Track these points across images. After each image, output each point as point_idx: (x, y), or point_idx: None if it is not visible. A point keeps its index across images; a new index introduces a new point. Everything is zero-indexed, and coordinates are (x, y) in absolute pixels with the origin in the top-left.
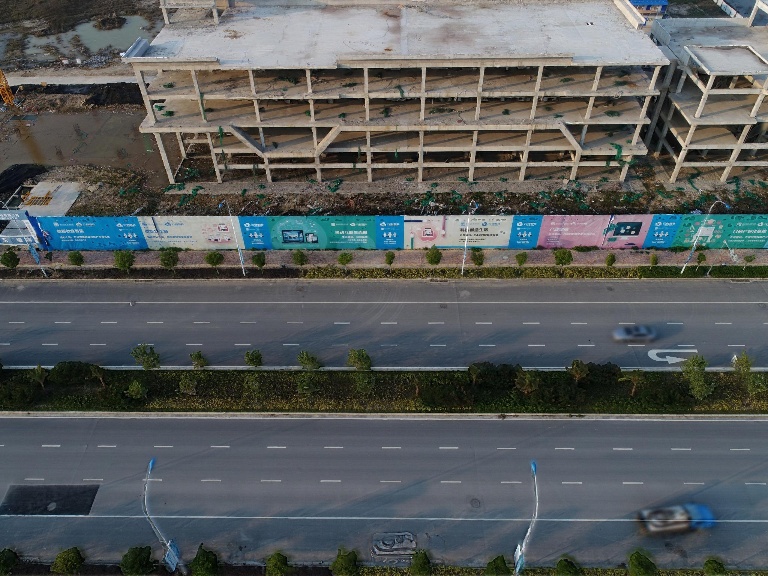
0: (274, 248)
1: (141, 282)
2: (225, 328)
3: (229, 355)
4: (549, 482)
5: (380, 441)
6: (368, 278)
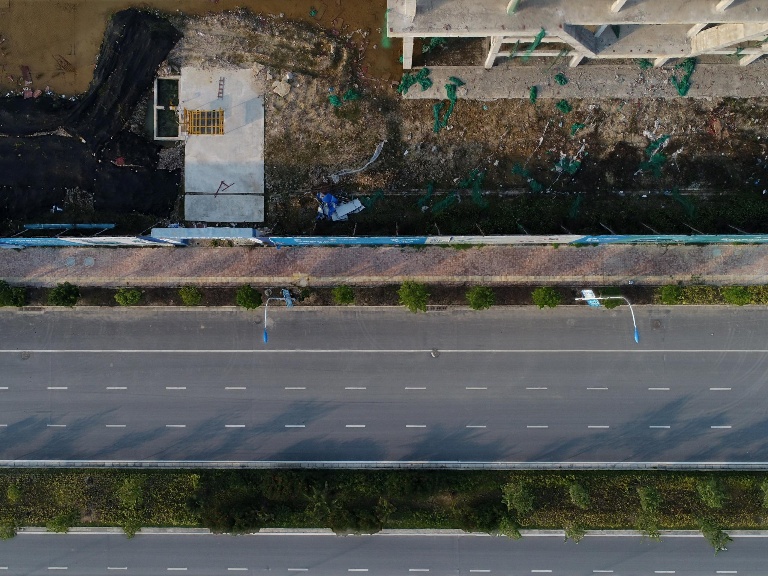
0: (610, 242)
1: (432, 311)
2: (570, 398)
3: (586, 444)
4: None
5: None
6: (751, 304)
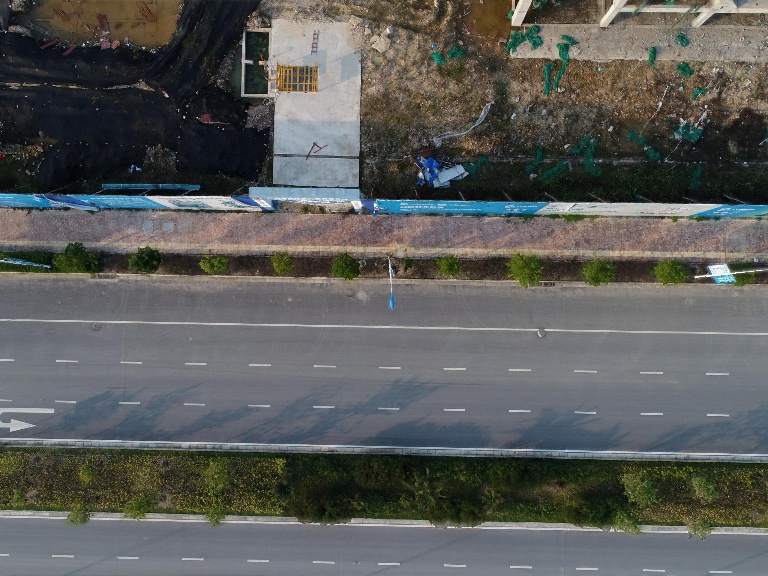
0: (734, 216)
1: (539, 287)
2: (687, 384)
3: (704, 434)
4: None
5: None
6: None
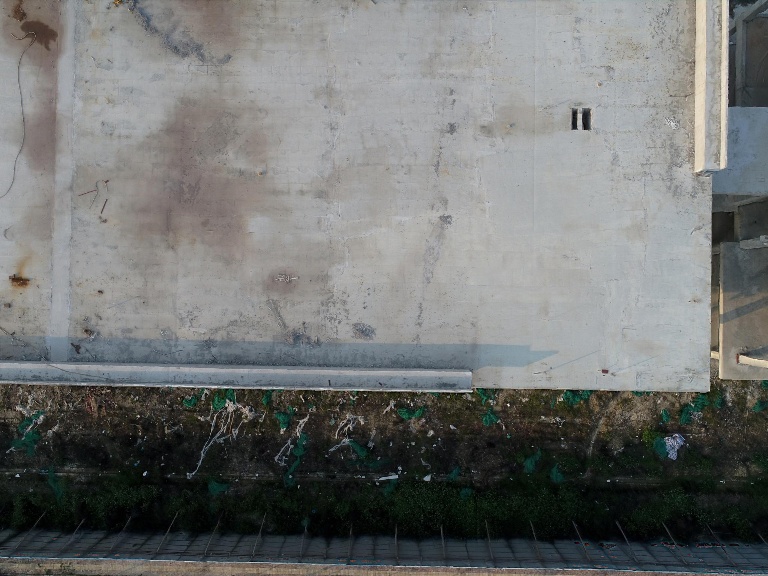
0: None
1: None
2: None
3: None
4: None
5: None
6: None
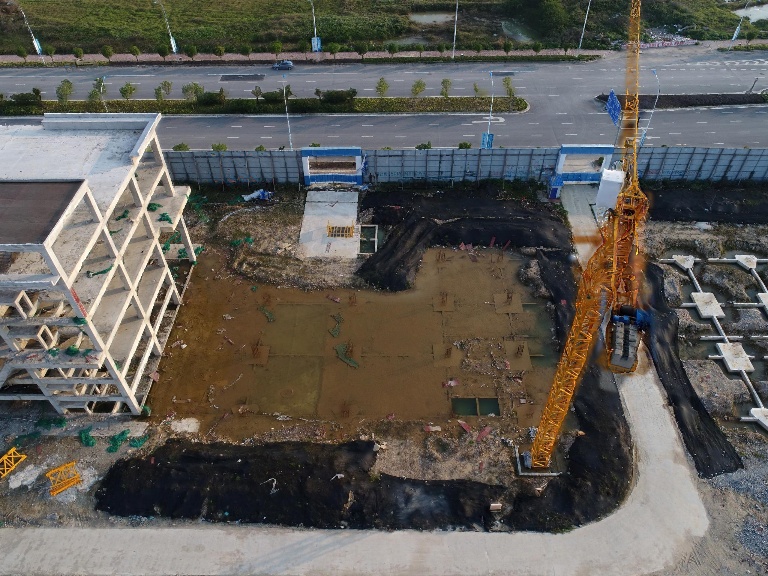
0: None
1: None
2: None
3: None
4: (2, 84)
5: (75, 94)
6: None
